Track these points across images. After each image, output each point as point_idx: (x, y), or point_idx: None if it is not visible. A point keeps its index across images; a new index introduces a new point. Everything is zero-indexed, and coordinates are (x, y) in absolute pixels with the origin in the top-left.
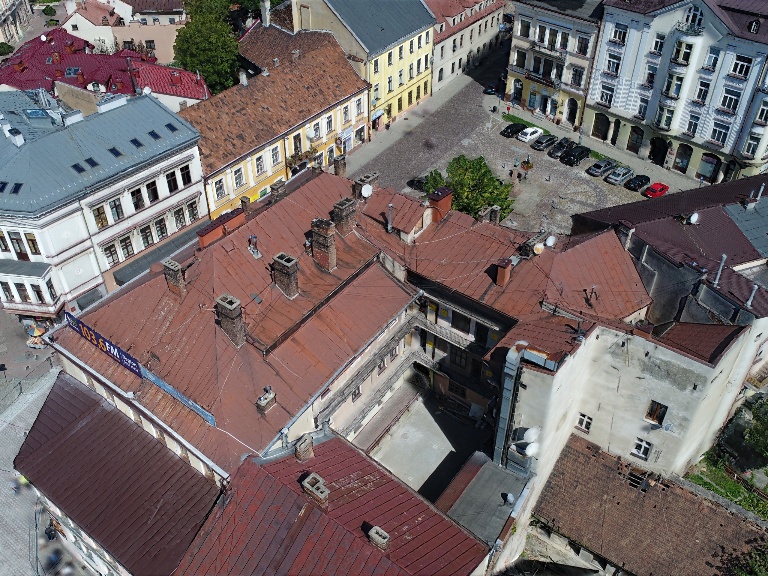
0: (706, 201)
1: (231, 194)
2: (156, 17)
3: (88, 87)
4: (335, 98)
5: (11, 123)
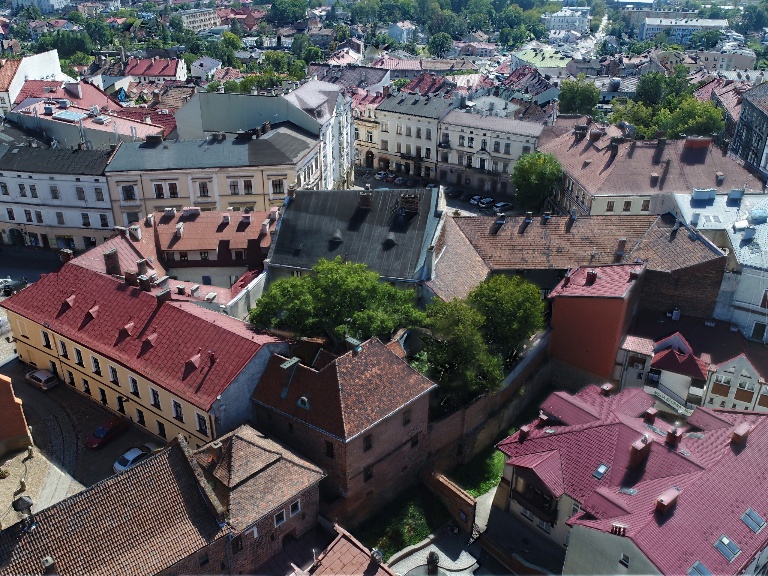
0: (497, 120)
1: None
2: None
3: None
4: None
5: None
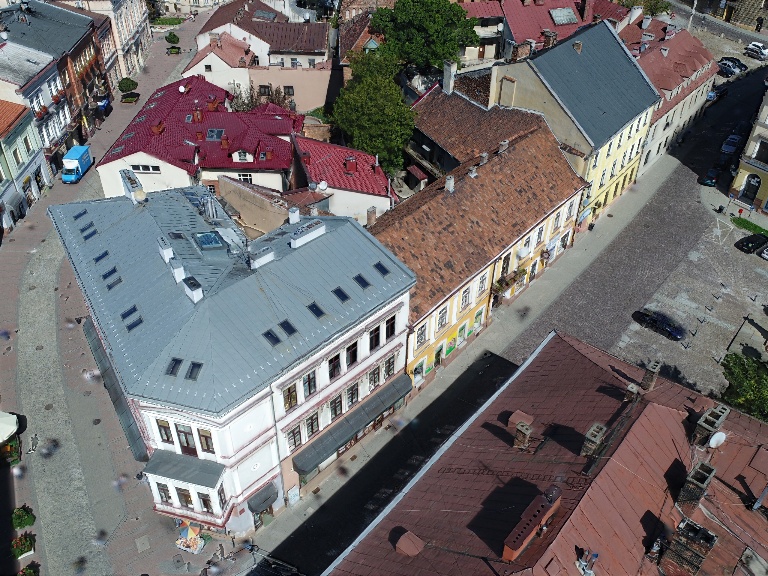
0: None
1: (431, 338)
2: (295, 57)
3: (233, 155)
4: (550, 204)
5: (180, 257)
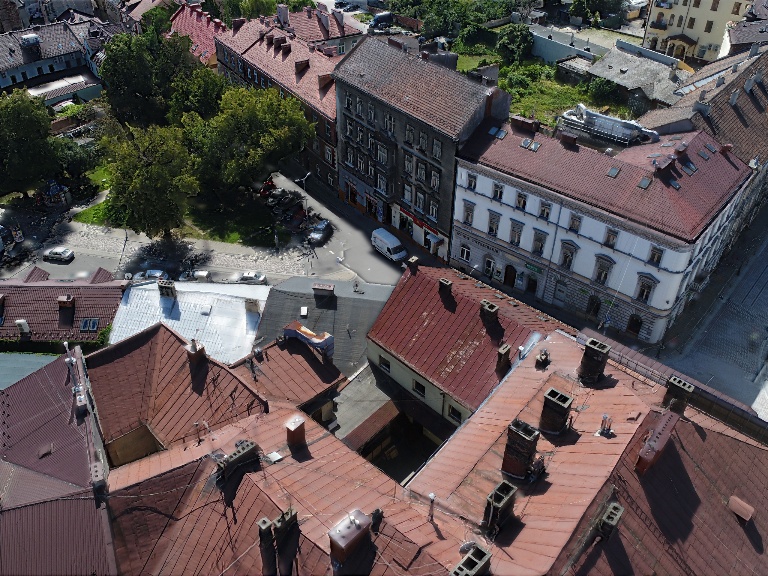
0: None
1: None
2: None
3: None
4: None
5: None
